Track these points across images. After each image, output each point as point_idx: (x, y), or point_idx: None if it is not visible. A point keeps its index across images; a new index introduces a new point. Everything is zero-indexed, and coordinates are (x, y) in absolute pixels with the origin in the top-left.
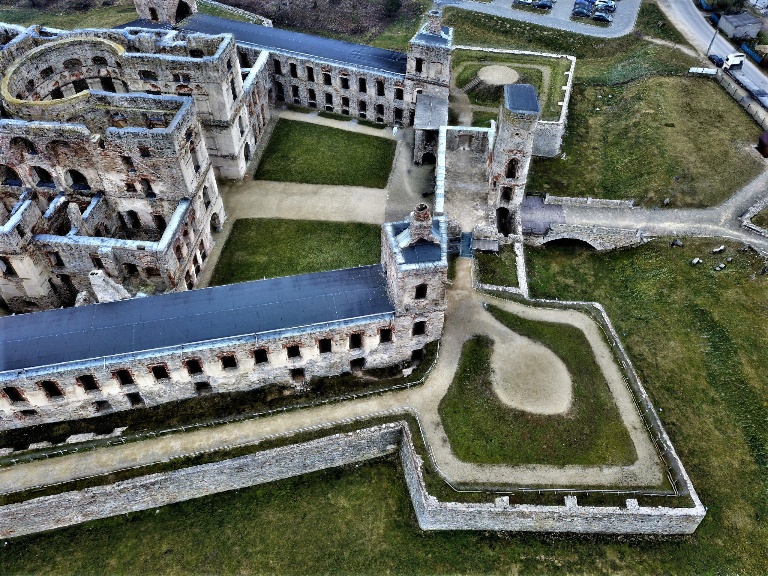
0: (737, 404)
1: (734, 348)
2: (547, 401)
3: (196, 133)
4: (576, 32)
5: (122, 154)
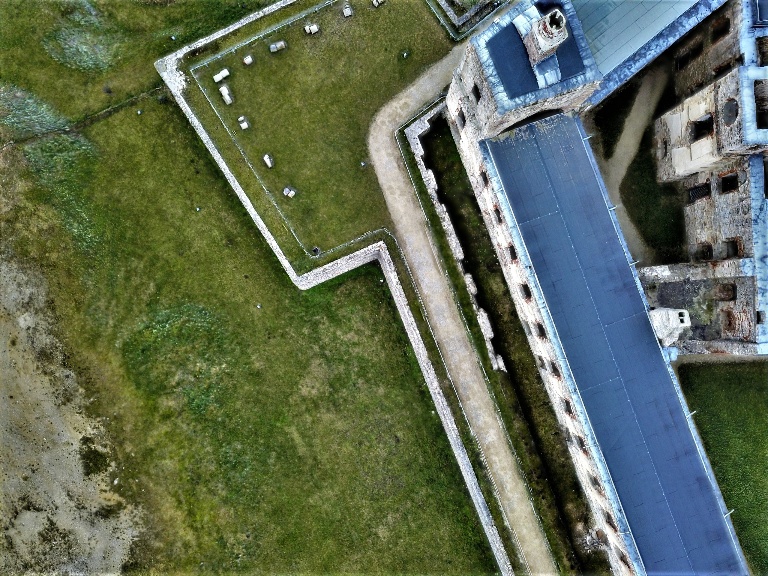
0: None
1: None
2: None
3: None
4: None
5: None
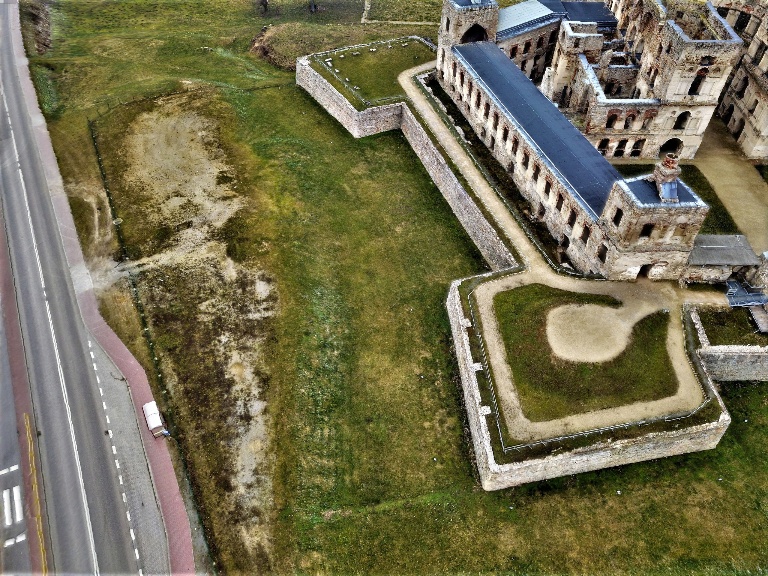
0: None
1: None
2: (562, 341)
3: (720, 69)
4: None
5: (662, 43)
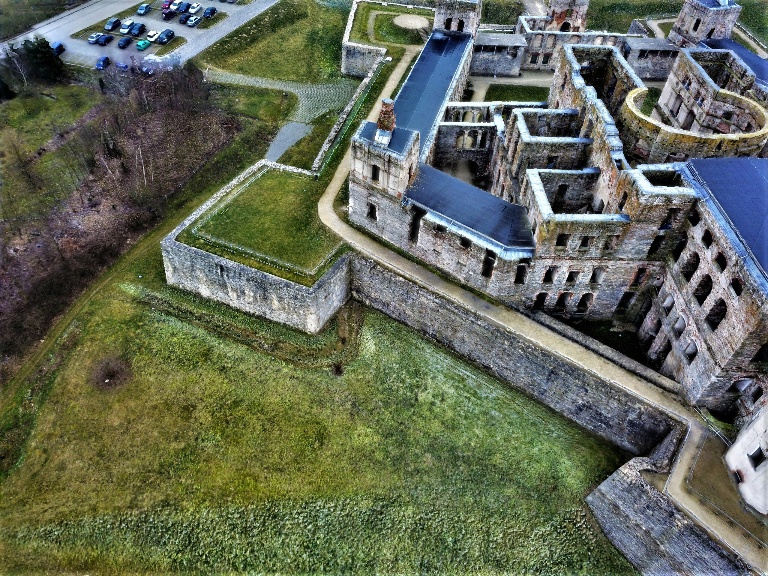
0: (652, 11)
1: (625, 4)
2: None
3: None
4: (271, 6)
5: None
